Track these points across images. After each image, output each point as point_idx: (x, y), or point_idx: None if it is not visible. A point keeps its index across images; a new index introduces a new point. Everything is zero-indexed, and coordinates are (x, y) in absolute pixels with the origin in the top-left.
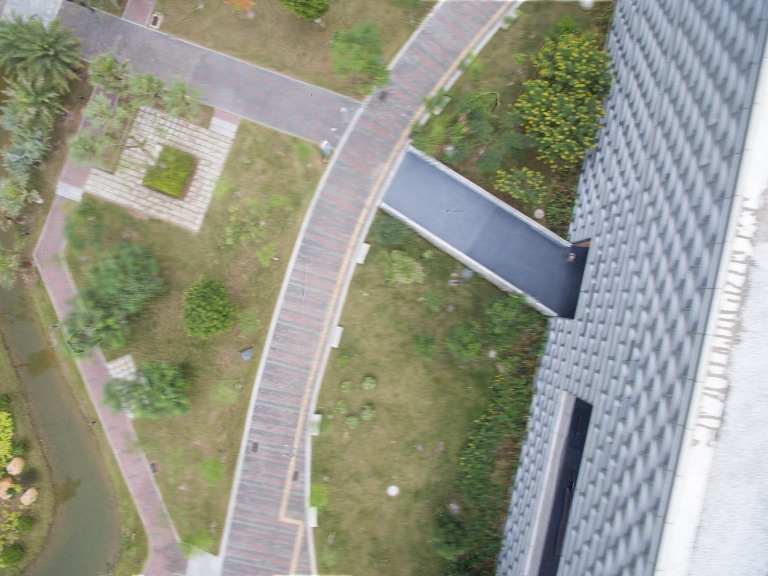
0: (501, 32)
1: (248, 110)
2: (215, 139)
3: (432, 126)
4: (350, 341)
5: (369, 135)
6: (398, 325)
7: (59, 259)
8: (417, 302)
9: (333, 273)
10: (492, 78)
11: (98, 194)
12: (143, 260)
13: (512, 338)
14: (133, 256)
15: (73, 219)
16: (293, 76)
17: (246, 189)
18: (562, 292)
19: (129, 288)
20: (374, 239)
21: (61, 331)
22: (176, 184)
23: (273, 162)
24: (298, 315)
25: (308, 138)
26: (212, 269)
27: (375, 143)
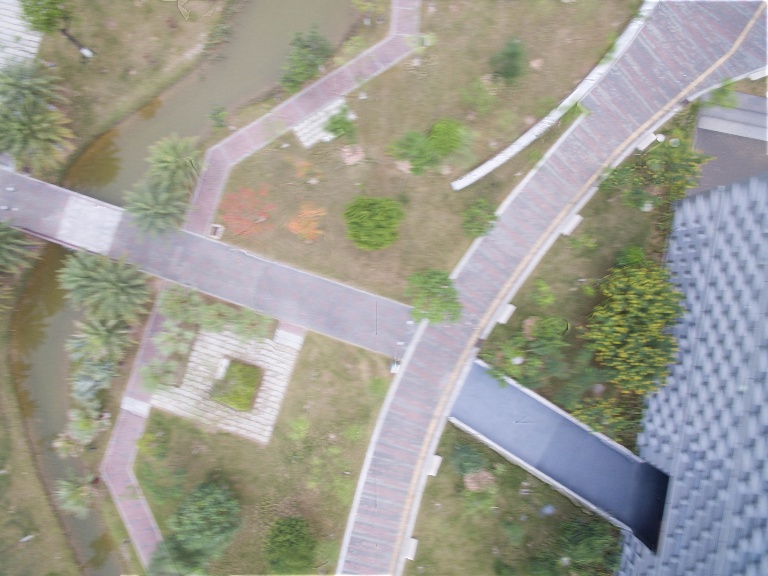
0: (562, 237)
1: (313, 322)
2: (281, 351)
3: (497, 334)
4: (424, 552)
5: (435, 345)
6: (471, 534)
7: (128, 476)
8: (489, 511)
9: (404, 484)
10: (555, 283)
11: (165, 408)
12: (213, 474)
13: (586, 551)
14: (203, 470)
15: (141, 435)
16: (357, 286)
17: (314, 402)
18: (636, 509)
19: (200, 502)
20: (444, 449)
21: (133, 548)
22: (244, 400)
23: (340, 374)
24: (371, 527)
25: (374, 349)
26: (283, 483)
27: (442, 353)
